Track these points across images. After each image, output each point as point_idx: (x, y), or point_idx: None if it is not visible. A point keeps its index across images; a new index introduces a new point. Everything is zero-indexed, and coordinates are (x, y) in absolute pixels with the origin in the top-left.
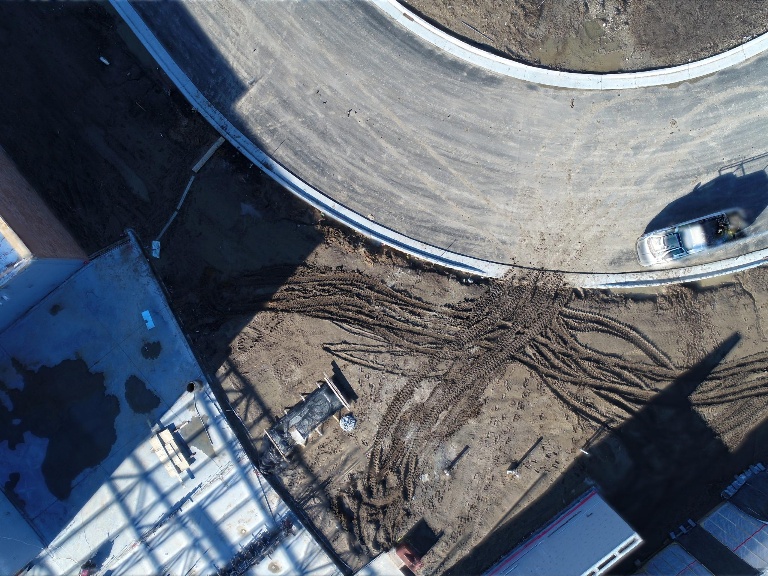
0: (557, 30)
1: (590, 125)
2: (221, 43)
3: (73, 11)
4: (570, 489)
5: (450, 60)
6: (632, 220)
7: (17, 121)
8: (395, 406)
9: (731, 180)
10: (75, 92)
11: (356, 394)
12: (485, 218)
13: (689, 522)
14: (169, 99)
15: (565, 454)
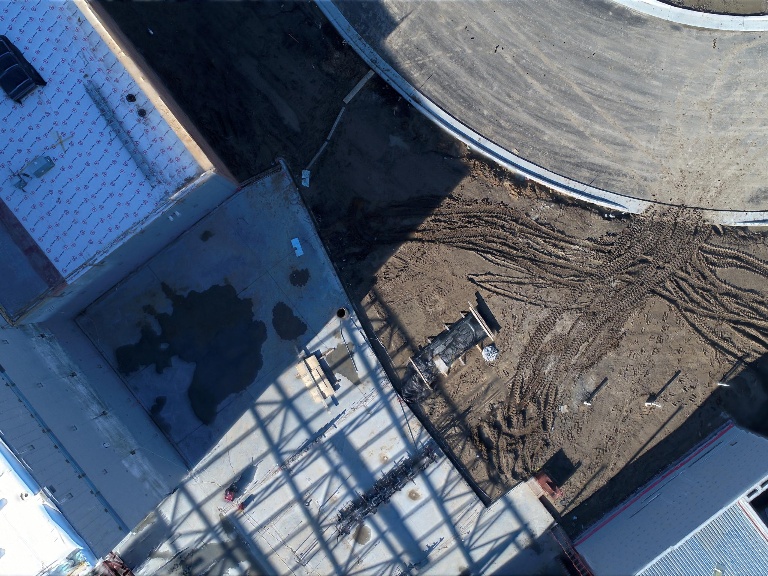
0: None
1: (731, 66)
2: None
3: None
4: (706, 423)
5: None
6: None
7: (172, 49)
8: (537, 337)
9: None
10: (230, 22)
11: (499, 325)
12: (627, 155)
13: None
14: (320, 32)
15: (702, 388)
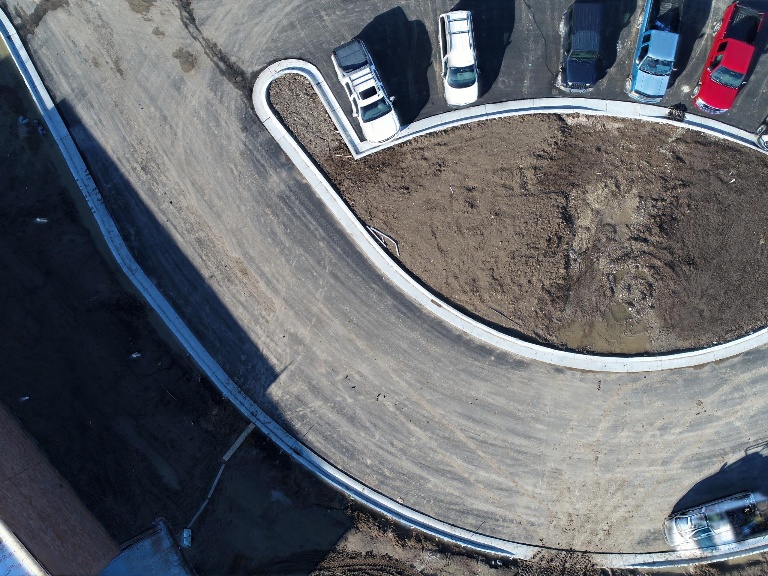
0: (583, 314)
1: (617, 407)
2: (251, 330)
3: (104, 302)
4: None
5: (478, 344)
6: (659, 500)
7: (49, 412)
8: None
9: (757, 460)
10: (107, 382)
11: None
12: (513, 500)
13: None
14: (199, 385)
15: None
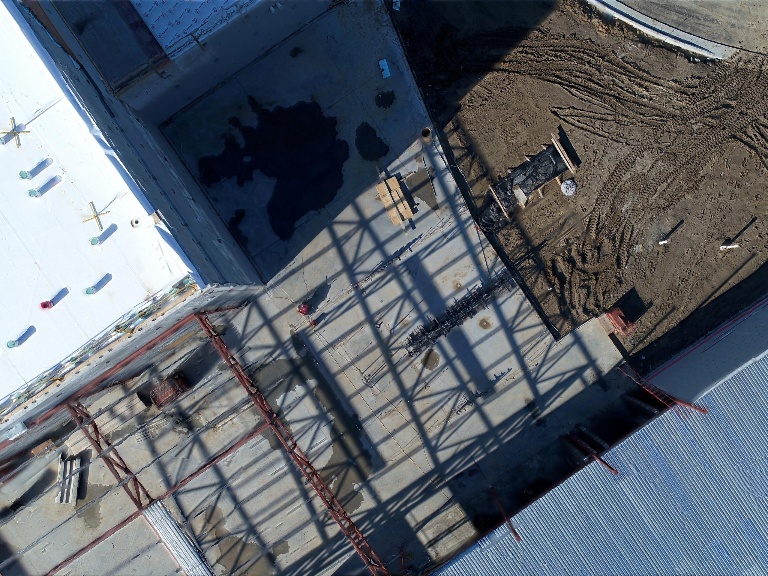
0: None
1: None
2: None
3: None
4: None
5: None
6: None
7: None
8: (616, 174)
9: None
10: None
11: (580, 159)
12: (716, 0)
13: None
14: None
15: None
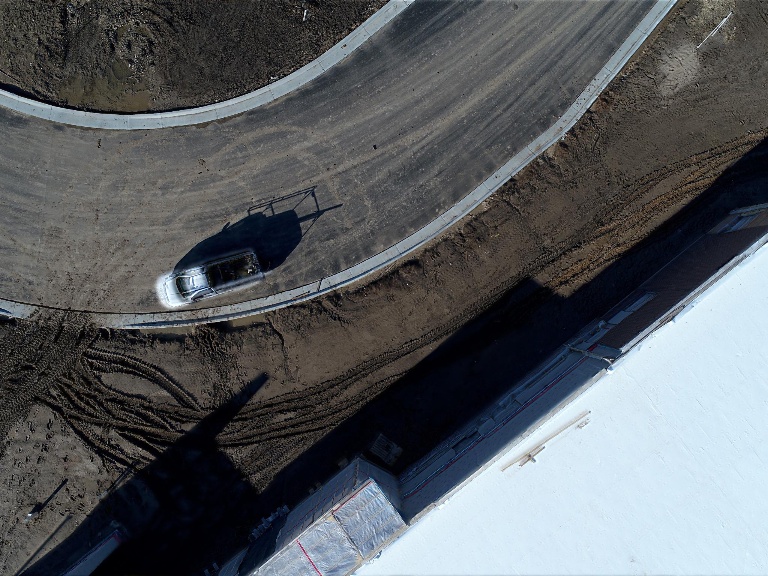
0: (83, 70)
1: (118, 165)
2: None
3: None
4: (96, 532)
5: None
6: (160, 260)
7: None
8: None
9: (260, 220)
10: None
11: None
12: (11, 258)
13: (213, 566)
14: None
15: (90, 496)
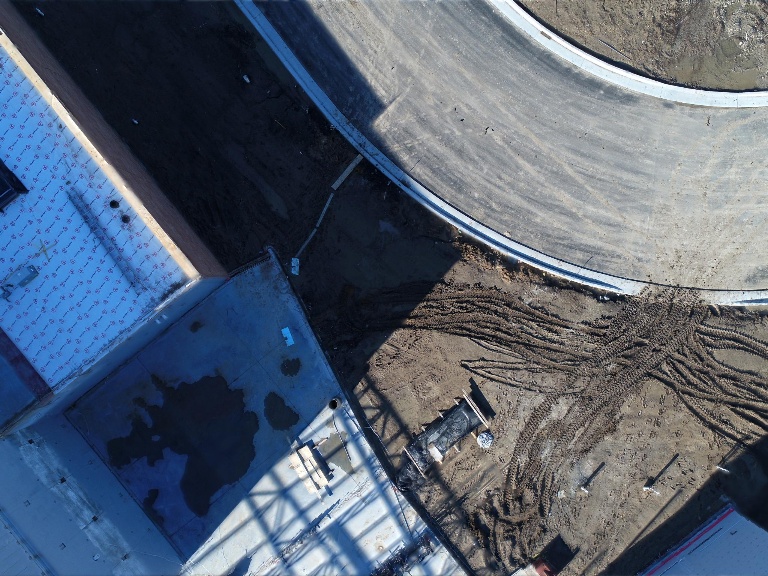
0: (693, 48)
1: (726, 143)
2: (359, 61)
3: (214, 29)
4: (706, 506)
5: (587, 78)
6: (767, 237)
7: (158, 139)
8: (532, 423)
9: None
10: (215, 110)
11: (494, 411)
12: (621, 235)
13: None
14: (307, 117)
15: (701, 471)
